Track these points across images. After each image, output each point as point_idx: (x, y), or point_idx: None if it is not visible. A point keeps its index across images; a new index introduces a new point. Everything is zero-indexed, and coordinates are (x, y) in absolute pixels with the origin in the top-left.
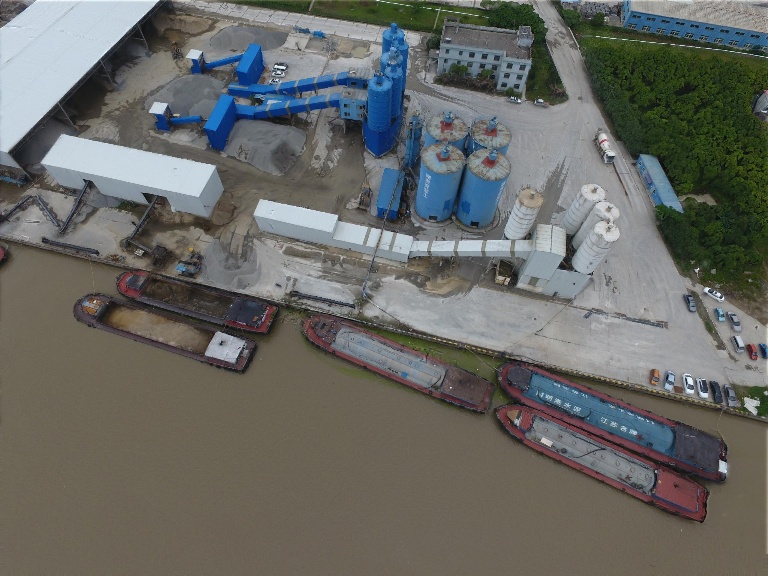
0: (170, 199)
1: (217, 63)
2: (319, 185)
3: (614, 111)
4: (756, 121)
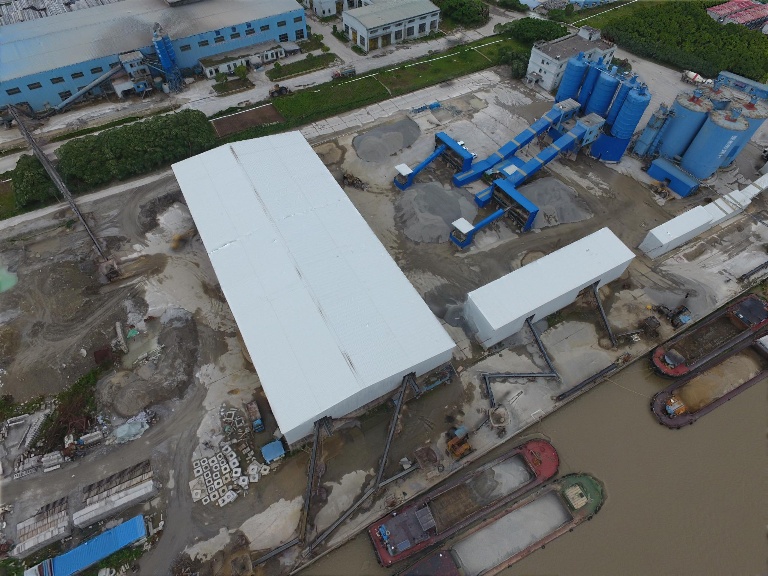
0: (603, 279)
1: (421, 167)
2: (623, 204)
3: (671, 57)
4: (738, 25)
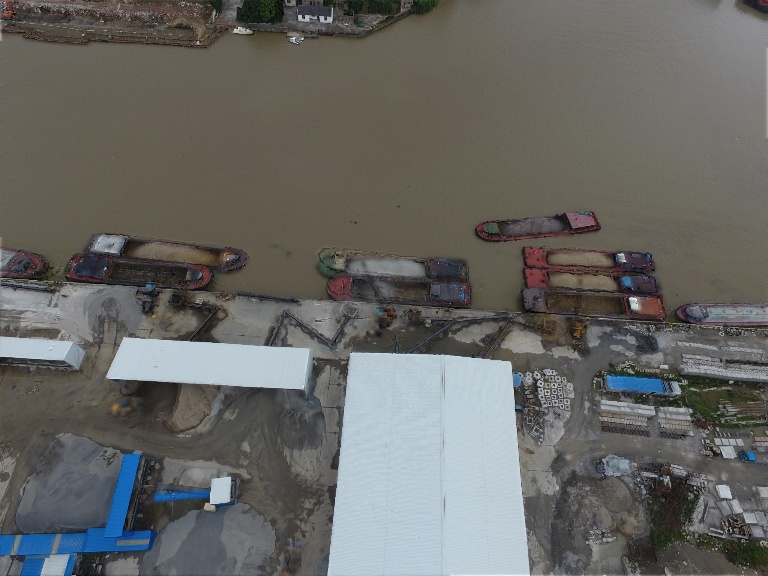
0: None
1: None
2: (9, 428)
3: None
4: None
